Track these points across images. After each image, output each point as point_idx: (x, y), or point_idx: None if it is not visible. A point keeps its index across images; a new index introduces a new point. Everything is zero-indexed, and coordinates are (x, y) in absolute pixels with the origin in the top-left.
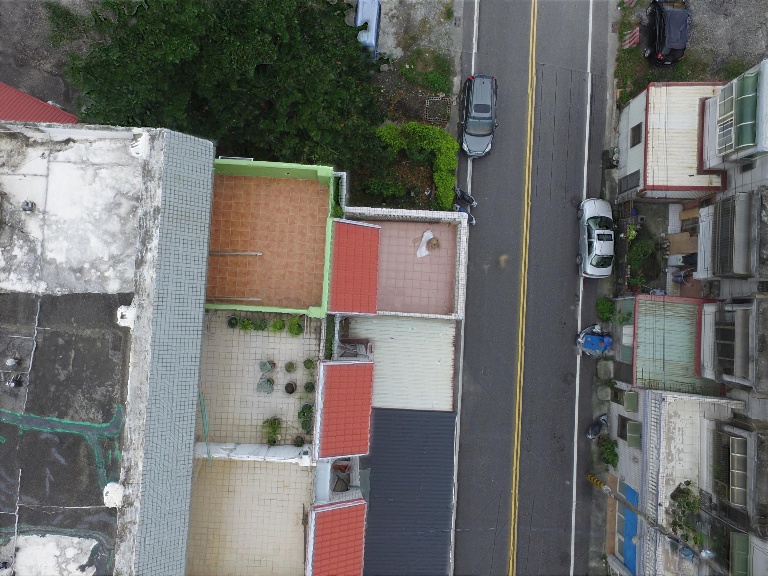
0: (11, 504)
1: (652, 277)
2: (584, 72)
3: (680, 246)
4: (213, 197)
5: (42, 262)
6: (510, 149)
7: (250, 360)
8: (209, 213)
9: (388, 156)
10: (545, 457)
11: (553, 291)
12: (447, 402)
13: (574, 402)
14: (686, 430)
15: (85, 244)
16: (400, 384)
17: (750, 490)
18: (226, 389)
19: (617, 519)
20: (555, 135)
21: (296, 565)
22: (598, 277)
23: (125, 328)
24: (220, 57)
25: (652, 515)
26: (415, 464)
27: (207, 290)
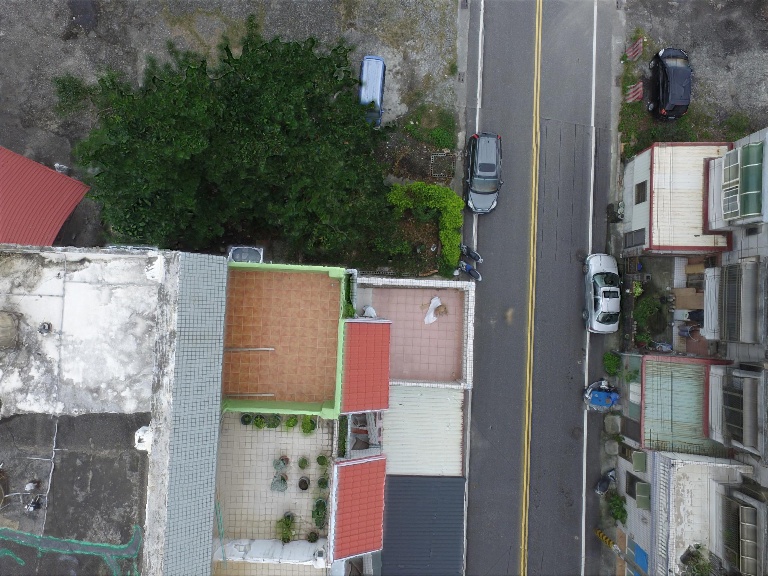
0: None
1: (658, 331)
2: (588, 126)
3: (686, 301)
4: None
5: (59, 382)
6: (515, 204)
7: (263, 455)
8: (223, 322)
9: (394, 216)
10: (554, 512)
11: (560, 346)
12: (456, 467)
13: (582, 457)
14: (695, 492)
15: (101, 364)
16: (409, 450)
17: (760, 562)
18: (240, 485)
19: (626, 574)
20: (560, 190)
21: None
22: (604, 333)
23: None
24: (229, 147)
25: None
26: (425, 530)
27: (222, 400)
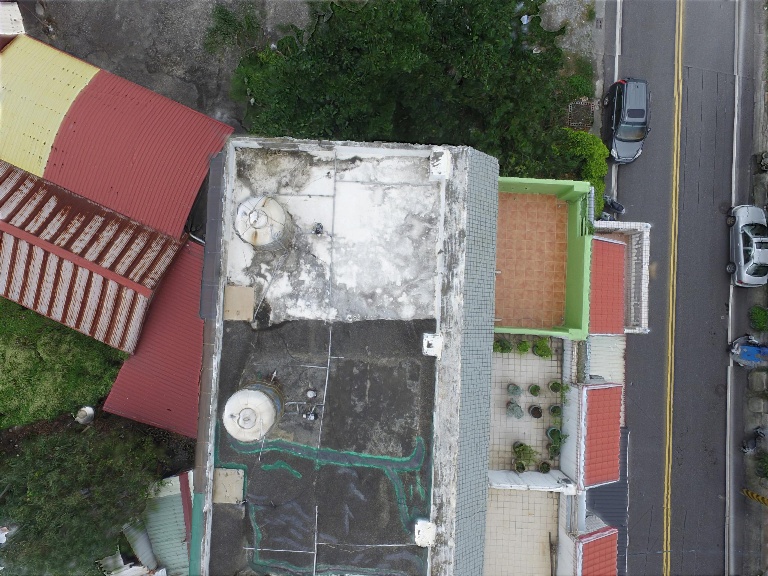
0: (310, 542)
1: None
2: (731, 74)
3: None
4: None
5: (331, 287)
6: (656, 154)
7: (491, 383)
8: None
9: None
10: (697, 471)
11: (702, 300)
12: None
13: (725, 414)
14: None
15: (376, 268)
16: None
17: None
18: None
19: None
20: (702, 140)
21: None
22: (752, 286)
23: (424, 357)
24: (436, 66)
25: None
26: None
27: None
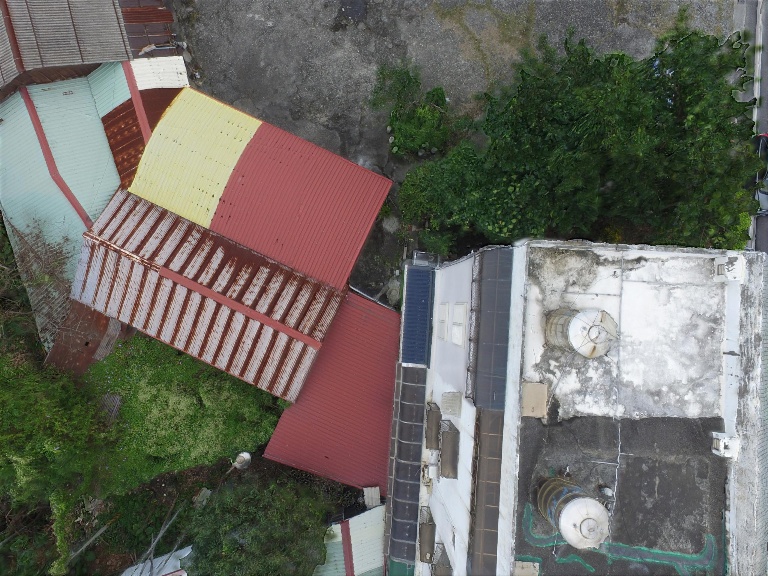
0: None
1: None
2: None
3: None
4: None
5: (619, 385)
6: None
7: None
8: None
9: None
10: None
11: None
12: None
13: None
14: None
15: (662, 366)
16: None
17: None
18: None
19: None
20: None
21: None
22: None
23: (714, 456)
24: None
25: None
26: None
27: None
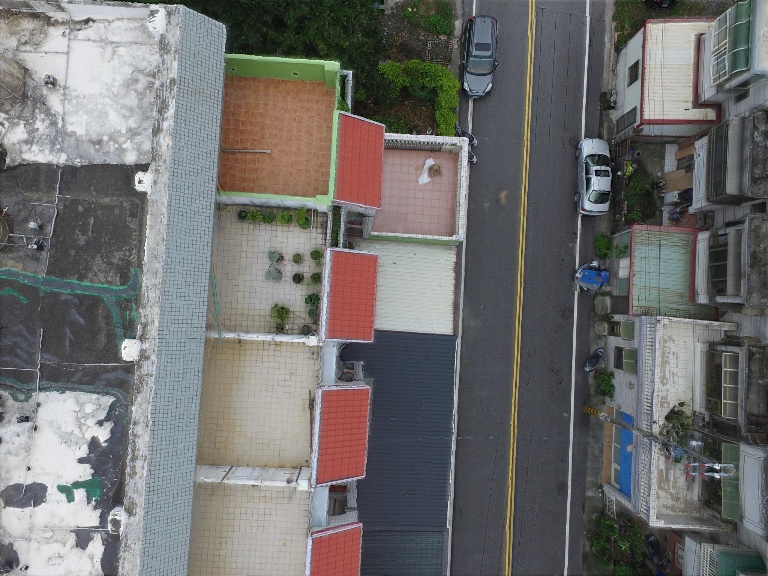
0: (33, 361)
1: (648, 215)
2: (583, 16)
3: (676, 184)
4: (224, 94)
5: (63, 135)
6: (510, 90)
7: (259, 253)
8: (221, 99)
9: (391, 93)
10: (543, 390)
11: (552, 229)
12: (448, 326)
13: (572, 337)
14: (680, 355)
15: (104, 118)
16: (402, 308)
17: (741, 401)
18: (236, 280)
19: (613, 450)
20: (554, 77)
21: (303, 448)
22: (596, 214)
23: (142, 196)
24: None
25: (647, 433)
26: (416, 385)
27: (219, 171)
